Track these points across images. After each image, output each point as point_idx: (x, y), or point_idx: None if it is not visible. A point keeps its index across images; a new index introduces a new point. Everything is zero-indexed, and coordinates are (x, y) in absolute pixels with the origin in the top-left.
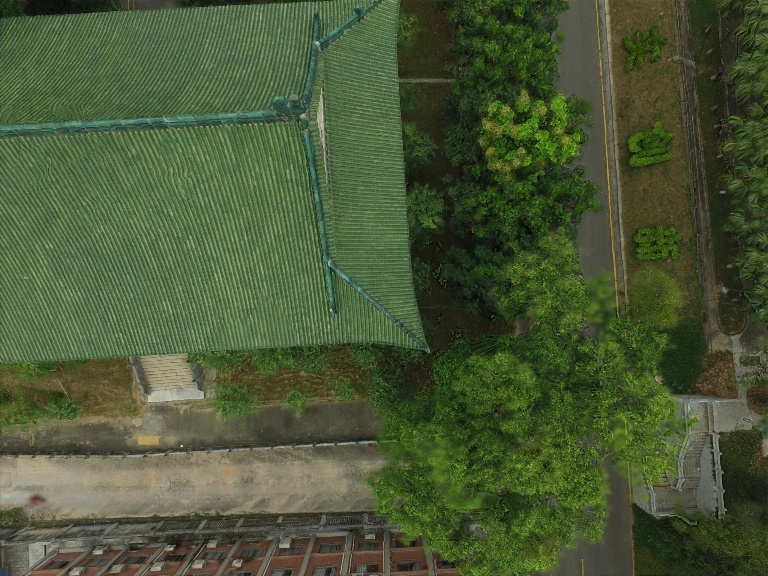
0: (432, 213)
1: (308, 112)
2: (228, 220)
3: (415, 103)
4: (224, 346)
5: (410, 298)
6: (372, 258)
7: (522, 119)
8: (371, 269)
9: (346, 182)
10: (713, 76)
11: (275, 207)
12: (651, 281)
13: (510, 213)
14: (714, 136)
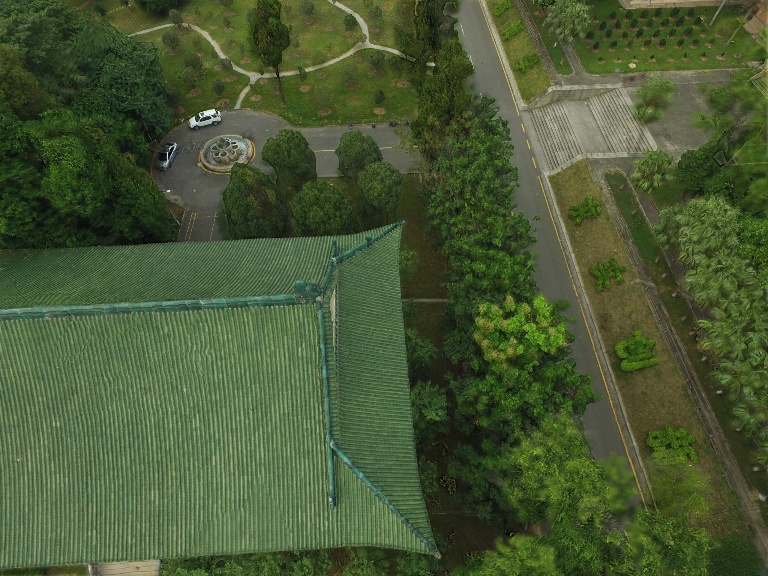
0: (435, 407)
1: (323, 296)
2: (237, 397)
3: (416, 318)
4: (206, 549)
5: (416, 490)
6: (376, 444)
7: (510, 317)
8: (374, 455)
9: (352, 368)
10: (674, 294)
11: (284, 384)
12: (679, 490)
13: (511, 401)
14: (692, 342)
